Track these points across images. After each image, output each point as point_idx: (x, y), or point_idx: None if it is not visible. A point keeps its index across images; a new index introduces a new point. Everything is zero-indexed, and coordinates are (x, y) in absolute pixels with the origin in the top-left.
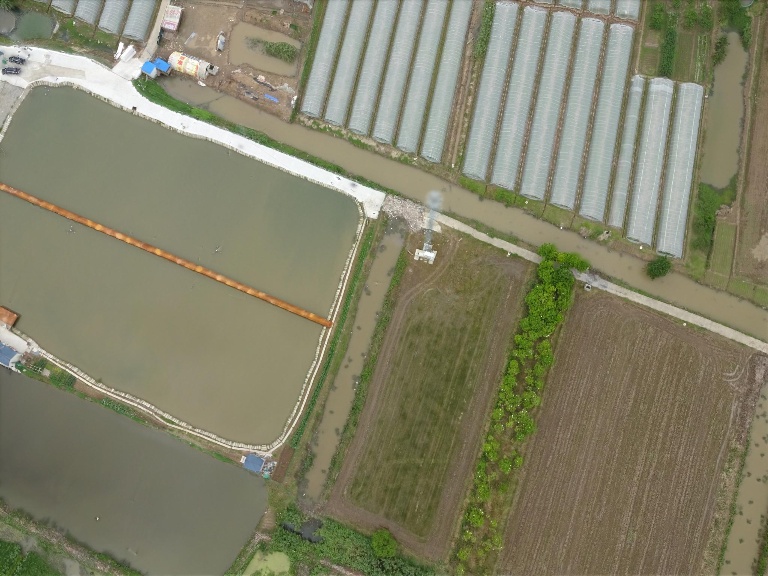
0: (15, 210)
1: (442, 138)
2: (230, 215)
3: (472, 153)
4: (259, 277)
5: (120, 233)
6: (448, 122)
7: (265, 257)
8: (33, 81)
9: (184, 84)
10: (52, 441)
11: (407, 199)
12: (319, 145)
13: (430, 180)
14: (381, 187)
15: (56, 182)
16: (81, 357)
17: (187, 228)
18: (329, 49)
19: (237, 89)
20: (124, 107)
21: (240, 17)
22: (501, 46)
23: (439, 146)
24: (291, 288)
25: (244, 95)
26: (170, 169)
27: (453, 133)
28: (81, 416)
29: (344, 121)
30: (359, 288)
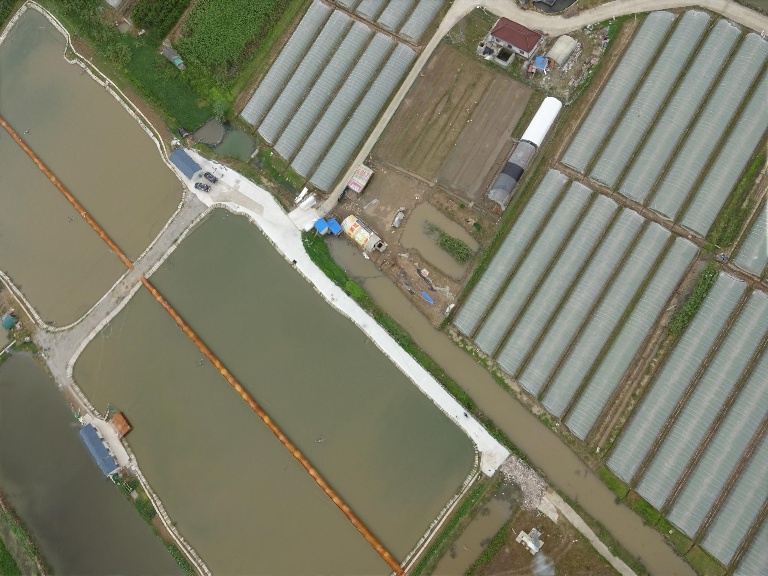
0: (162, 323)
1: (596, 414)
2: (345, 409)
3: (625, 447)
4: (350, 488)
5: (240, 385)
6: (610, 396)
7: (363, 469)
8: (218, 202)
9: (349, 249)
10: (118, 562)
11: (532, 468)
12: (459, 366)
13: (566, 455)
14: (508, 442)
15: (204, 310)
16: (168, 492)
17: (301, 405)
18: (506, 264)
19: (397, 275)
20: (286, 257)
21: (427, 196)
22: (707, 328)
23: (589, 423)
24: (377, 514)
25: (402, 284)
26: (306, 337)
27: (611, 412)
28: (149, 550)
29: (494, 350)
30: (445, 546)
